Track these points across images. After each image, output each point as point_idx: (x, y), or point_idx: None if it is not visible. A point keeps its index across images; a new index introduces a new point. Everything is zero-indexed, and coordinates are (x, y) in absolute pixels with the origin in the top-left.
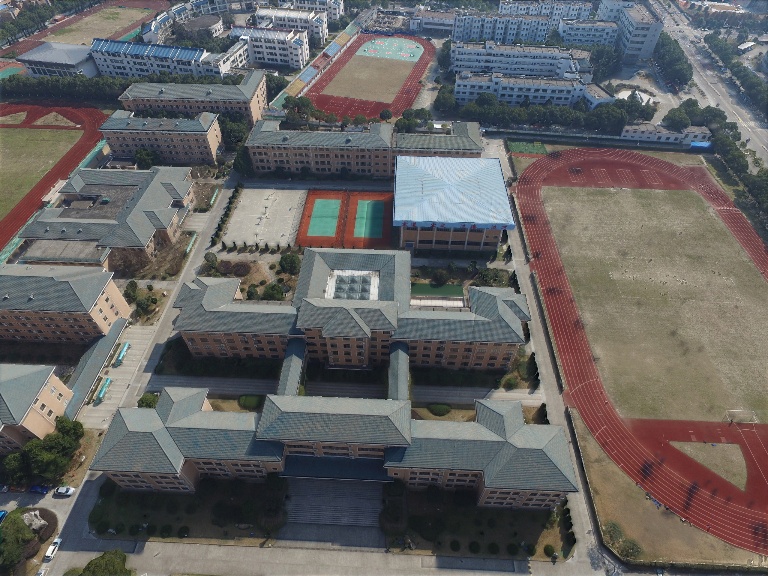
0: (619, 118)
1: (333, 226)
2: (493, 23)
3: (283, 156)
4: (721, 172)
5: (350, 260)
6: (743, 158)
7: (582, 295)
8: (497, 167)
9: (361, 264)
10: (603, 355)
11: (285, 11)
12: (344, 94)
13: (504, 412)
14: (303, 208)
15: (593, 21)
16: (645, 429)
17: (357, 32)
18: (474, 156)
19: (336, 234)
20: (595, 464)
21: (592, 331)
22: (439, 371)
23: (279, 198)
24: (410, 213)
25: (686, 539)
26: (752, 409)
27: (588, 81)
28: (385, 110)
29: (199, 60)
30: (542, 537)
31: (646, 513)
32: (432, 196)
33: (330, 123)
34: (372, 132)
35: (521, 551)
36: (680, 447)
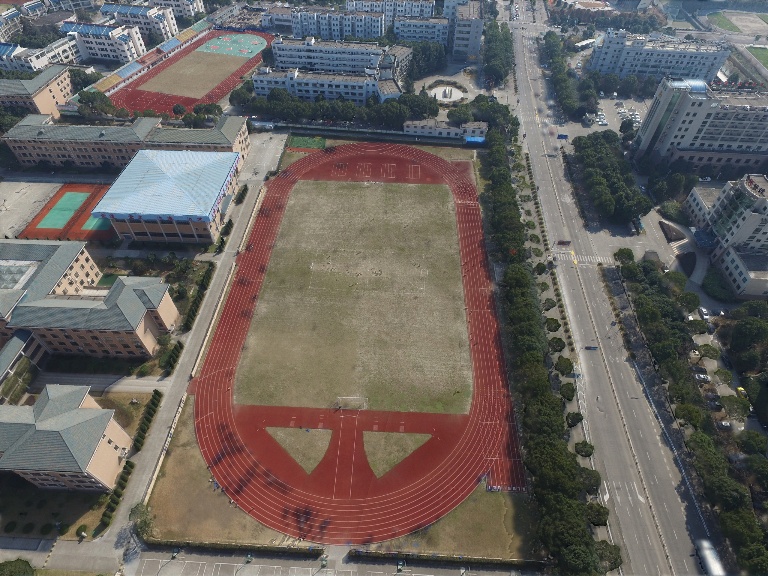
0: (397, 113)
1: (67, 218)
2: (327, 19)
3: (43, 150)
4: (485, 167)
5: (16, 250)
6: (499, 153)
7: (270, 286)
8: (231, 161)
9: (26, 254)
10: (254, 344)
11: (128, 7)
12: (159, 89)
13: (55, 396)
14: (48, 201)
15: (425, 18)
16: (250, 415)
17: (208, 28)
18: (226, 150)
19: (65, 226)
20: (179, 448)
21: (258, 321)
22: (81, 359)
23: (30, 191)
24: (111, 205)
25: (223, 520)
26: (367, 396)
27: (388, 77)
28: (176, 105)
29: (10, 55)
30: (83, 517)
31: (199, 495)
32: (144, 189)
33: (122, 118)
34: (133, 126)
35: (54, 531)
36: (273, 432)
